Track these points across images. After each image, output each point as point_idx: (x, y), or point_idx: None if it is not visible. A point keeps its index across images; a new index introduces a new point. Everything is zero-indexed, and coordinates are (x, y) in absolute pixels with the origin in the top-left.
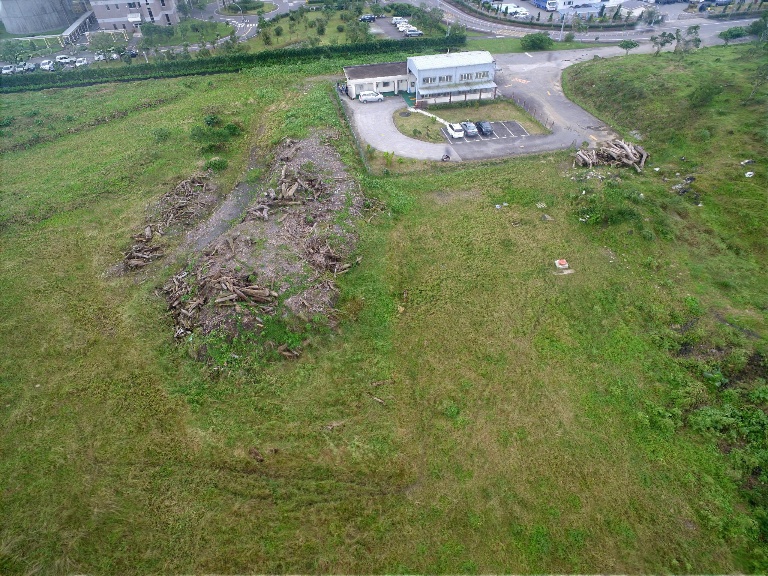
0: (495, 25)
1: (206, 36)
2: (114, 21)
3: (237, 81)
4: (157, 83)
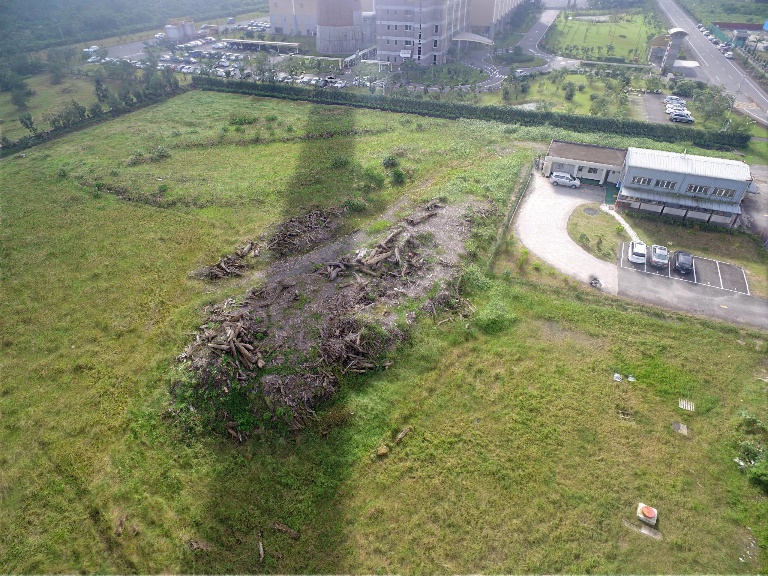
0: None
1: (456, 80)
2: (389, 54)
3: (447, 128)
4: (378, 114)
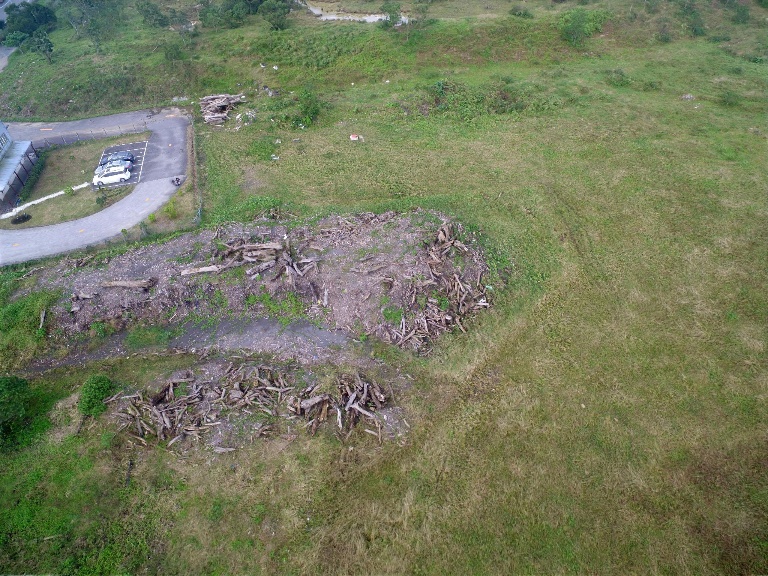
0: None
1: None
2: None
3: None
4: None
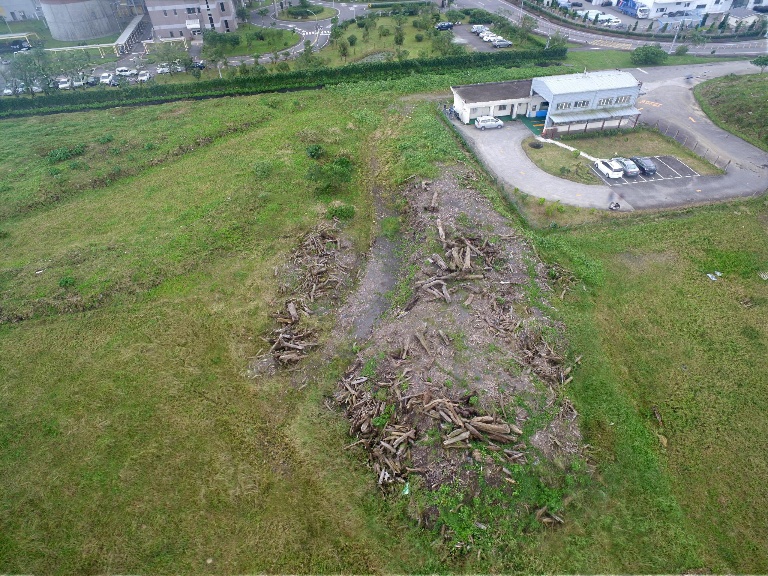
0: (586, 34)
1: (272, 45)
2: (171, 28)
3: (324, 100)
4: (236, 102)
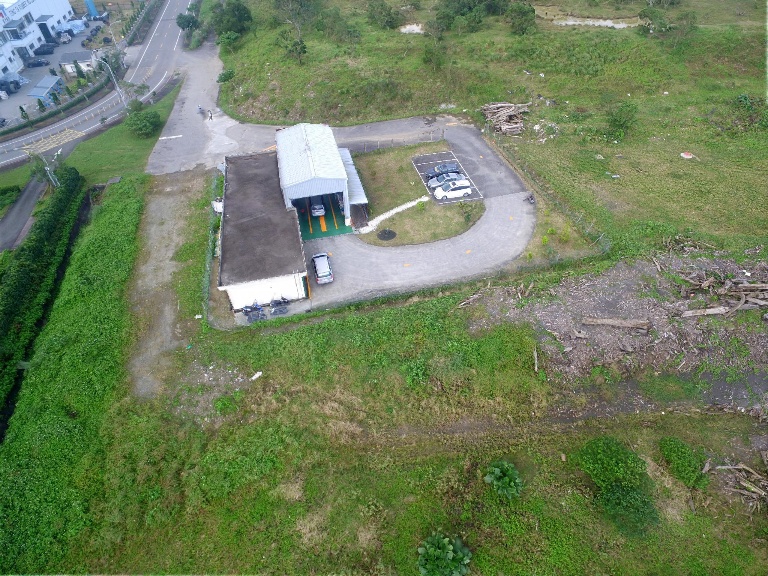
0: None
1: None
2: None
3: None
4: None
